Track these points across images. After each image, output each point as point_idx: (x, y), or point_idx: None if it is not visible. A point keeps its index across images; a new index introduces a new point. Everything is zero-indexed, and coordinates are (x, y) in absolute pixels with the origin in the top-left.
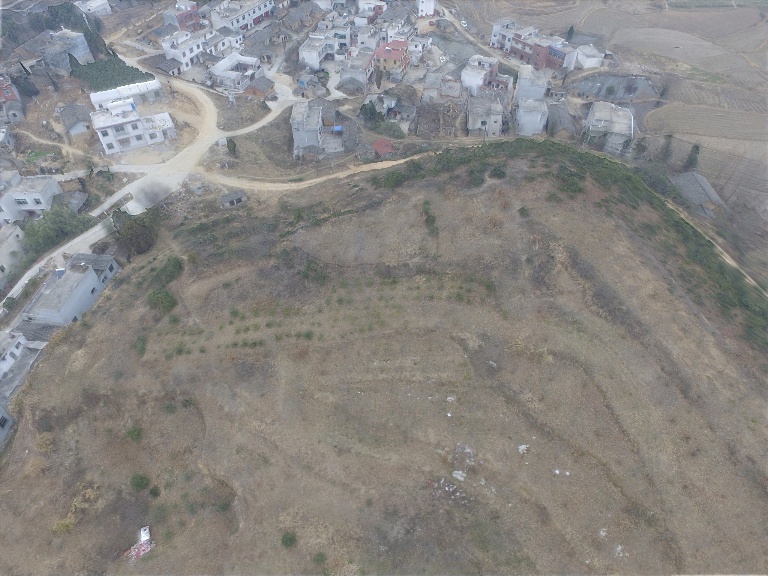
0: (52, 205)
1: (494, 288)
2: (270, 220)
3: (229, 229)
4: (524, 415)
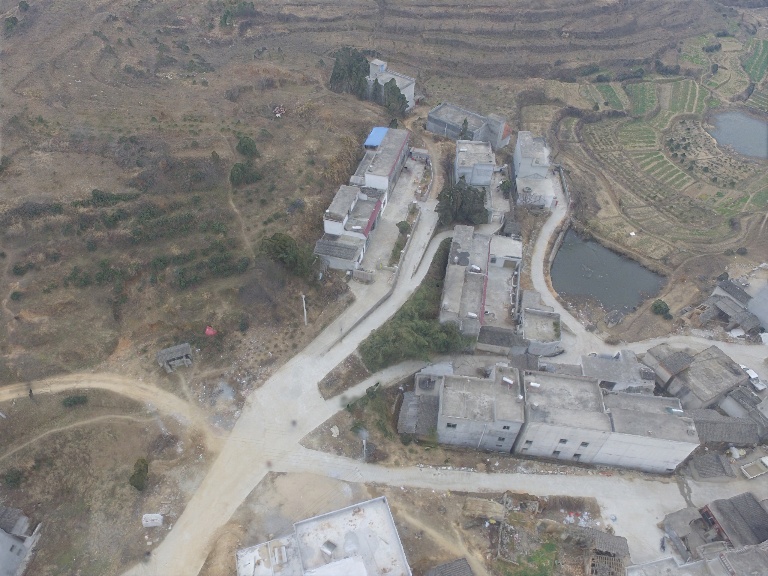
0: (410, 336)
1: None
2: (139, 230)
3: (186, 244)
4: None
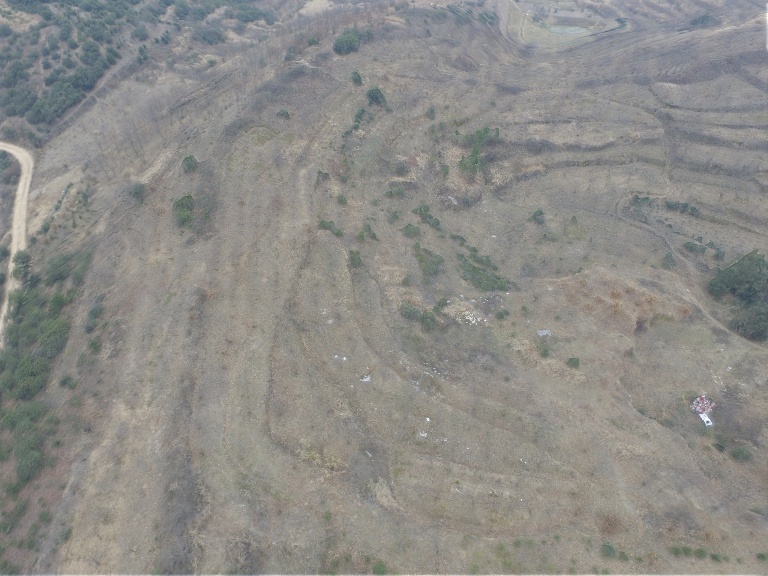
0: None
1: (322, 574)
2: None
3: None
4: (353, 406)
